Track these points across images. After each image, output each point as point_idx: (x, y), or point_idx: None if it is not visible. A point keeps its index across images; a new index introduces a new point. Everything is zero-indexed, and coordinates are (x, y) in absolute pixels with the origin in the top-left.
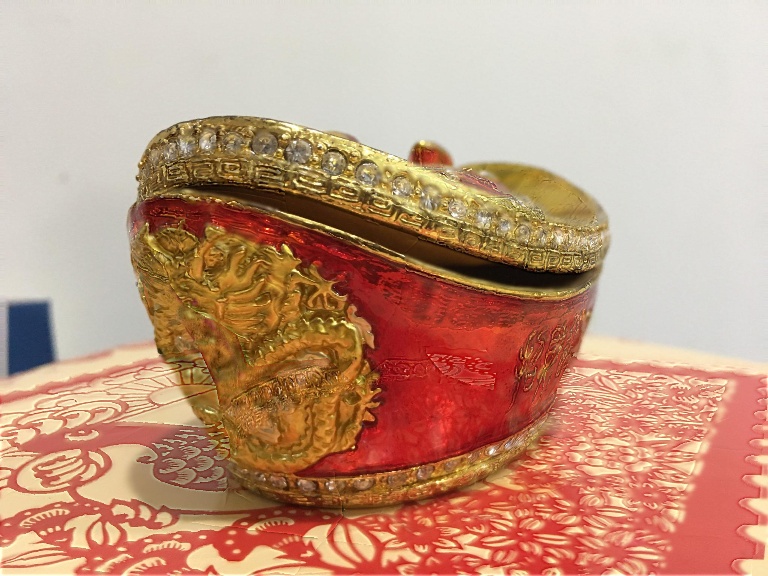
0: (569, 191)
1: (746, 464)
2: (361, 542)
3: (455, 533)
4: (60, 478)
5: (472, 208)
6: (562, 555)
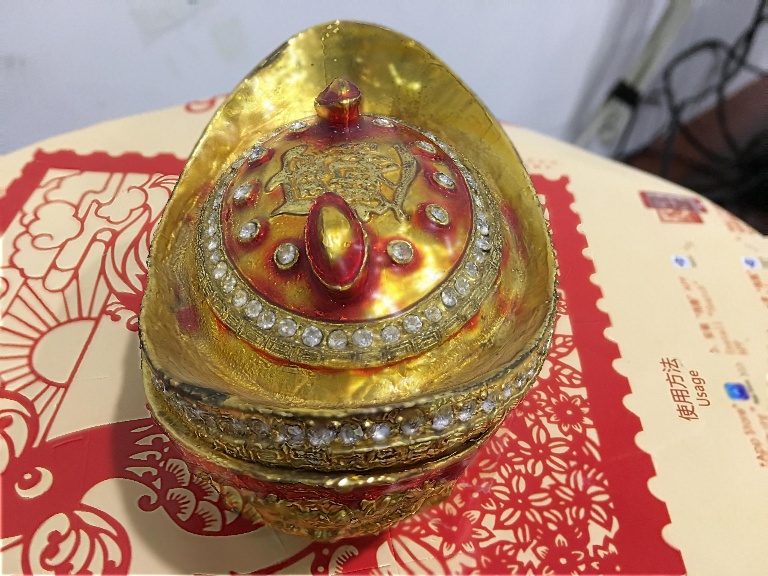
0: (470, 96)
1: (606, 342)
2: (425, 557)
3: (479, 517)
4: (91, 572)
5: (541, 355)
6: (557, 518)
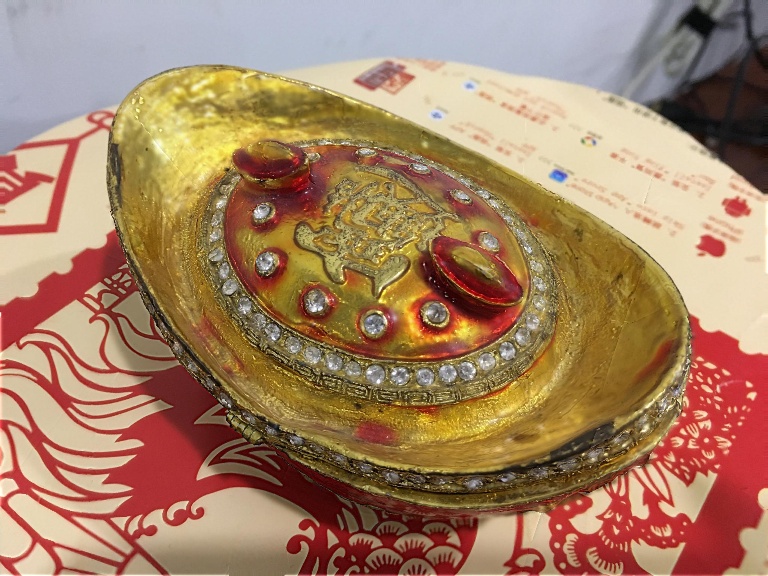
0: (304, 87)
1: None
2: None
3: None
4: None
5: None
6: None
